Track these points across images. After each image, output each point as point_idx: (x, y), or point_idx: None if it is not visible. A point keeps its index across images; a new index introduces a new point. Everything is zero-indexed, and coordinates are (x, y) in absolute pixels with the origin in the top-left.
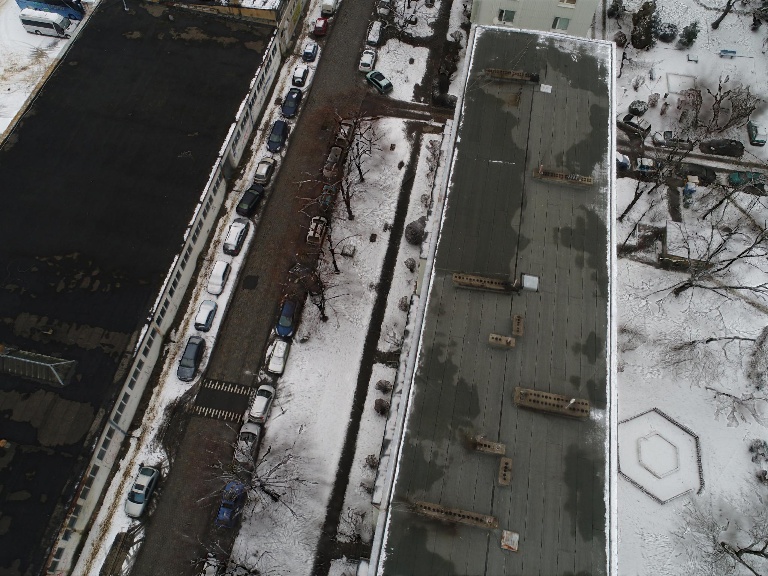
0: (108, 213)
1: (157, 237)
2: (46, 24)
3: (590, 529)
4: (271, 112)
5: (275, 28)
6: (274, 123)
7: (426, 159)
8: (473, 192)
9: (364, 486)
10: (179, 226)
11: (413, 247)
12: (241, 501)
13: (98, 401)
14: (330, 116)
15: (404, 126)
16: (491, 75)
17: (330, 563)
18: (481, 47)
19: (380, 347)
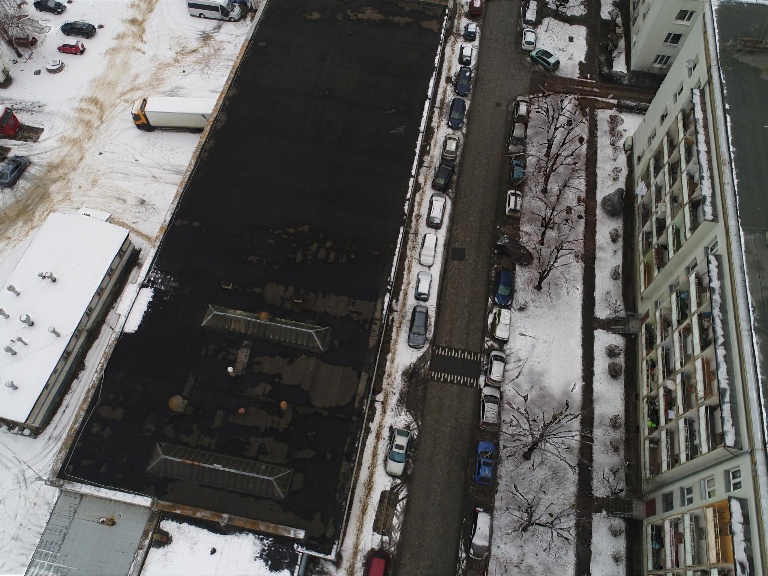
0: (328, 187)
1: (379, 210)
2: (212, 7)
3: None
4: (444, 90)
5: (446, 7)
6: (451, 101)
7: (610, 133)
8: (757, 156)
9: (612, 444)
10: (397, 199)
11: (610, 219)
12: None
13: (359, 365)
14: (502, 93)
15: (576, 102)
16: (743, 44)
17: (592, 517)
18: (722, 18)
19: (598, 314)
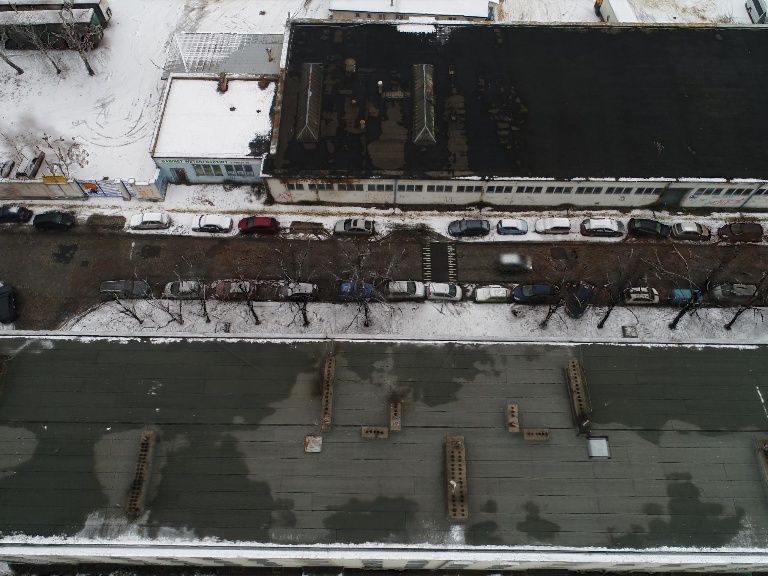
0: (574, 117)
1: (566, 158)
2: (761, 9)
3: (336, 526)
4: None
5: None
6: None
7: None
8: (700, 373)
9: None
10: (584, 171)
11: None
12: (360, 298)
13: (408, 168)
14: None
15: None
16: None
17: None
18: None
19: None
